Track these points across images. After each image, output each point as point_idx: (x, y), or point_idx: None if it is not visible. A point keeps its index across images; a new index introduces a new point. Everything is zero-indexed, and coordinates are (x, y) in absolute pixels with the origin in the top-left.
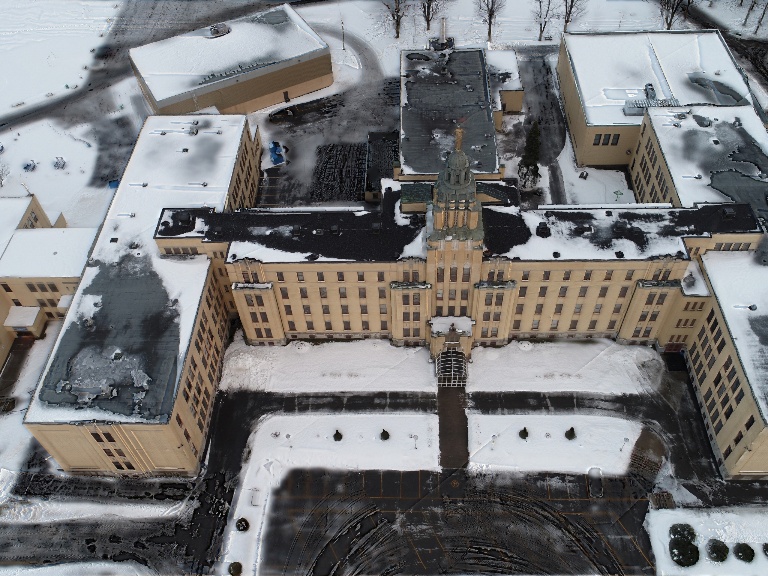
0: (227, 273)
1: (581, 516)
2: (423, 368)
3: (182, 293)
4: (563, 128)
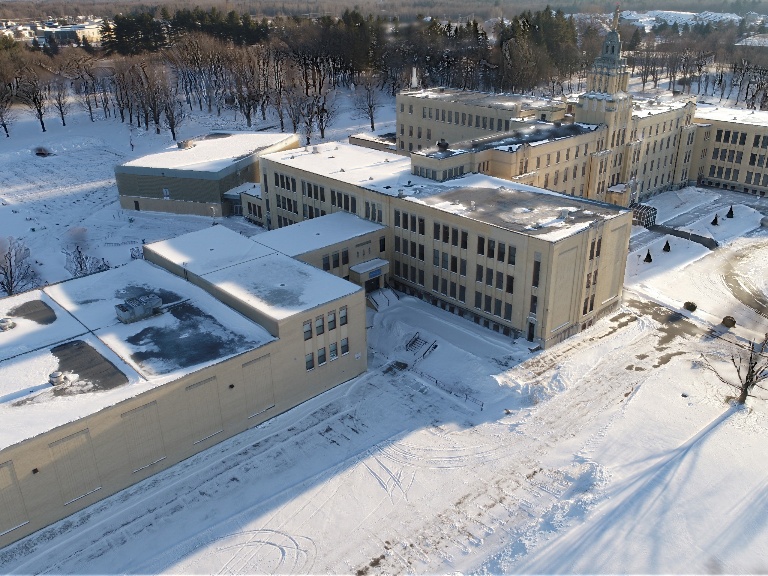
0: None
1: None
2: None
3: (497, 185)
4: None
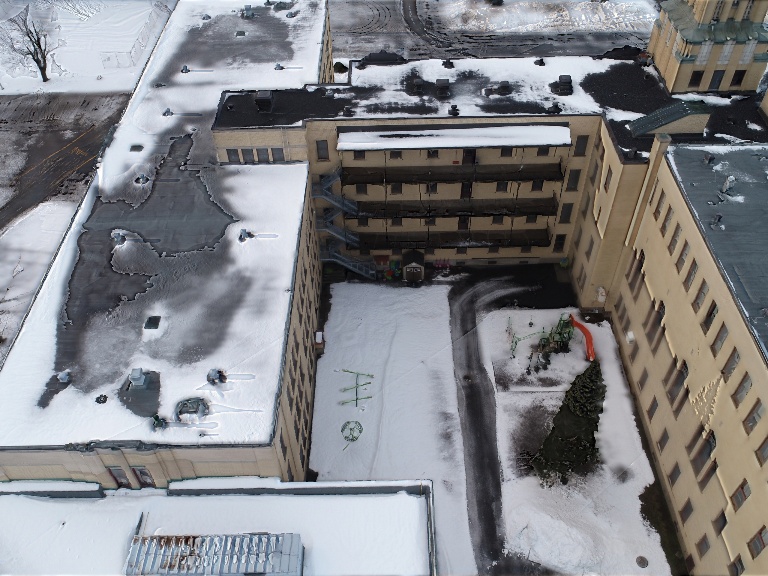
0: None
1: None
2: None
3: None
4: None
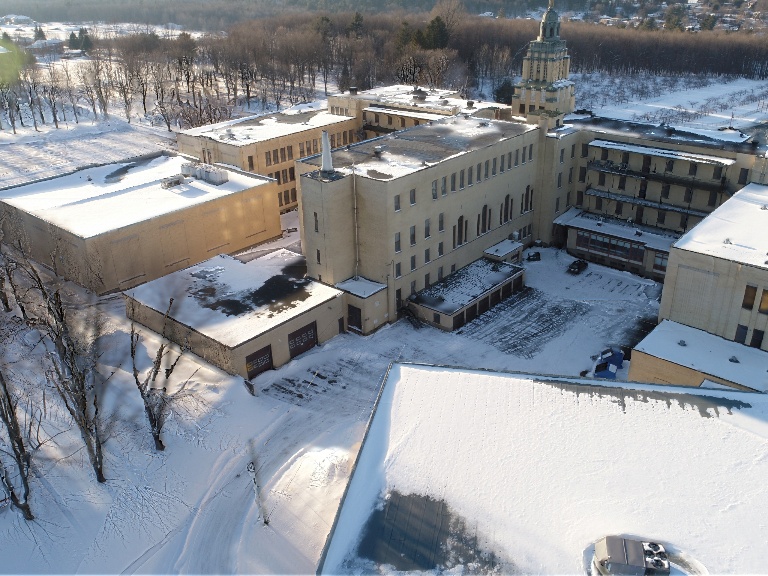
0: None
1: None
2: None
3: None
4: None
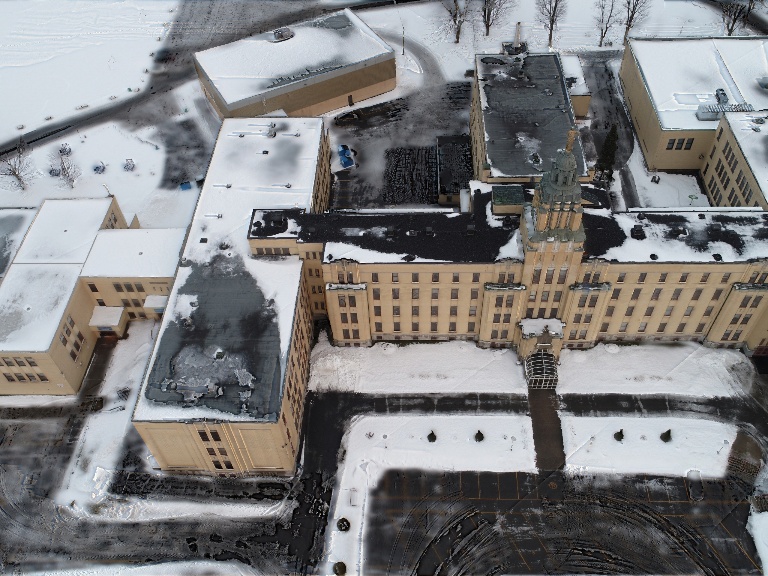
0: (317, 274)
1: (683, 518)
2: (511, 370)
3: (277, 293)
4: (630, 133)
